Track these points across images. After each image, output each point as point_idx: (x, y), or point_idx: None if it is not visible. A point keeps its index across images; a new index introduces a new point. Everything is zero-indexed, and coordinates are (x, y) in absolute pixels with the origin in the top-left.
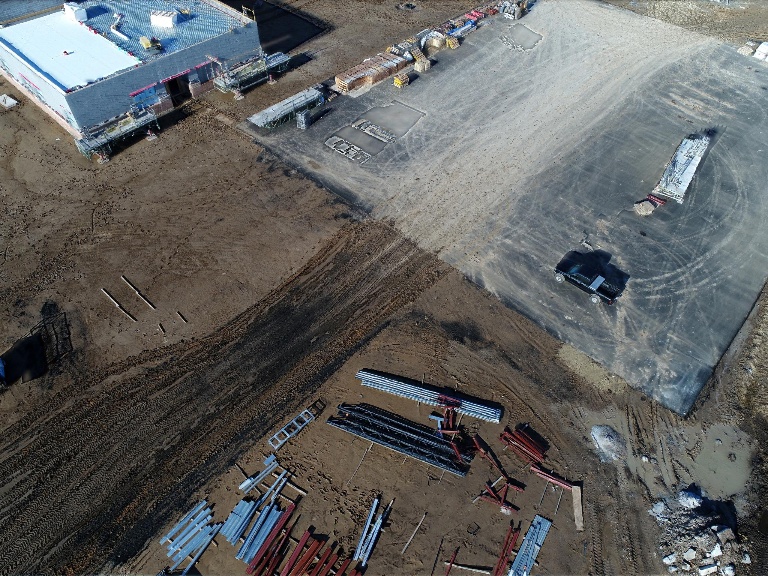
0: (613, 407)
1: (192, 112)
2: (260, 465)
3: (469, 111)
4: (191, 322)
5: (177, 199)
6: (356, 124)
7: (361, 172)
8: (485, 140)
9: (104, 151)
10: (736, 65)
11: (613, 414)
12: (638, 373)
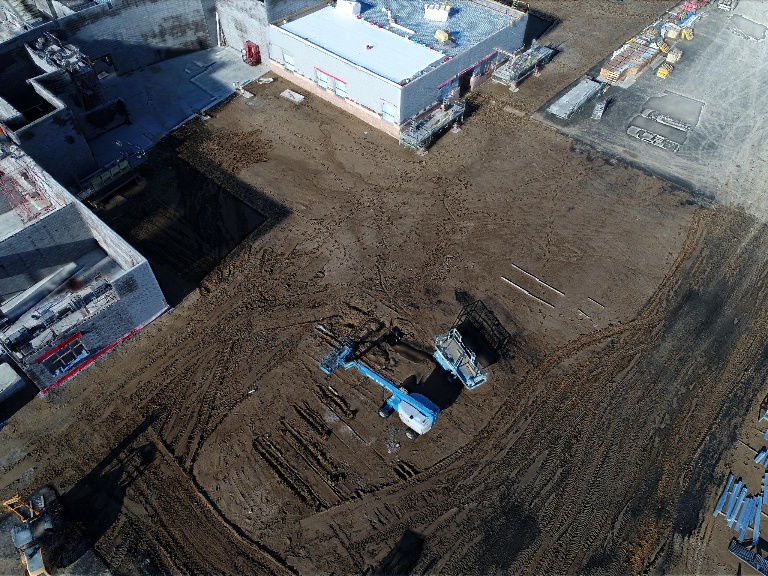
0: None
1: (478, 104)
2: (762, 440)
3: (744, 100)
4: (608, 307)
5: (517, 189)
6: (645, 114)
7: (680, 160)
8: None
9: None
10: None
11: None
12: None
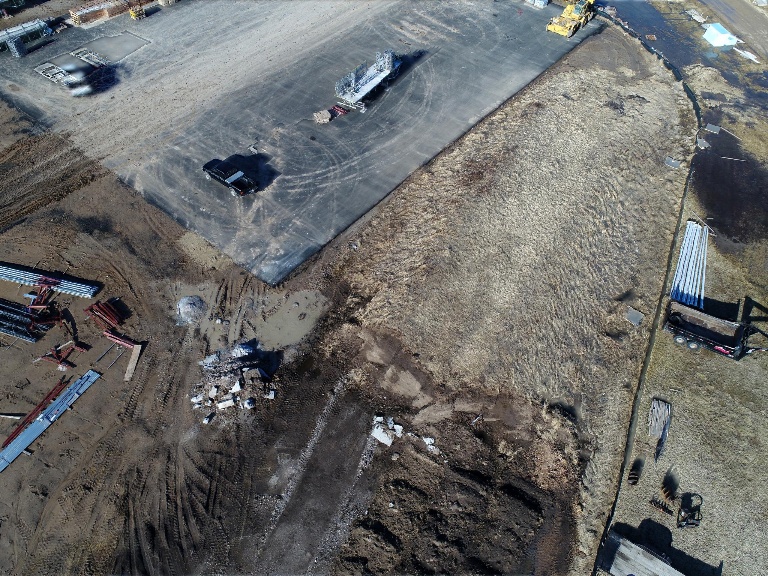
0: (210, 281)
1: None
2: None
3: (195, 39)
4: None
5: None
6: (75, 52)
7: (59, 93)
8: (198, 63)
9: None
10: None
11: (207, 287)
12: (247, 252)
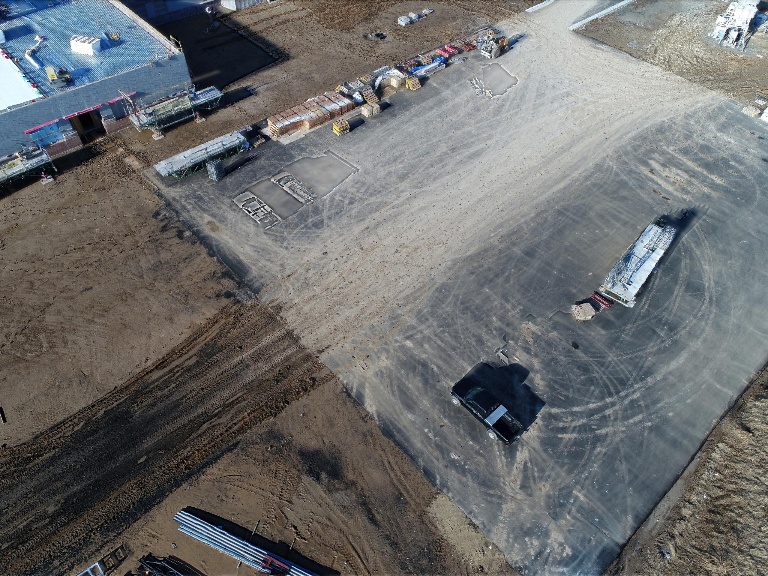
0: None
1: (101, 151)
2: None
3: (409, 169)
4: (10, 423)
5: (49, 259)
6: (276, 178)
7: (263, 239)
8: (417, 207)
9: None
10: (737, 128)
11: None
12: (523, 545)
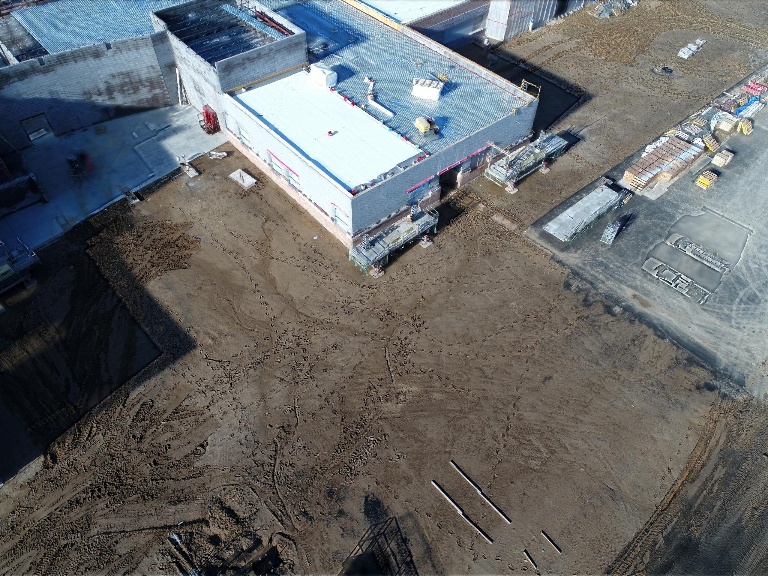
0: None
1: (462, 208)
2: None
3: None
4: (566, 552)
5: (483, 340)
6: (671, 241)
7: (707, 317)
8: None
9: (381, 263)
10: None
11: None
12: None
